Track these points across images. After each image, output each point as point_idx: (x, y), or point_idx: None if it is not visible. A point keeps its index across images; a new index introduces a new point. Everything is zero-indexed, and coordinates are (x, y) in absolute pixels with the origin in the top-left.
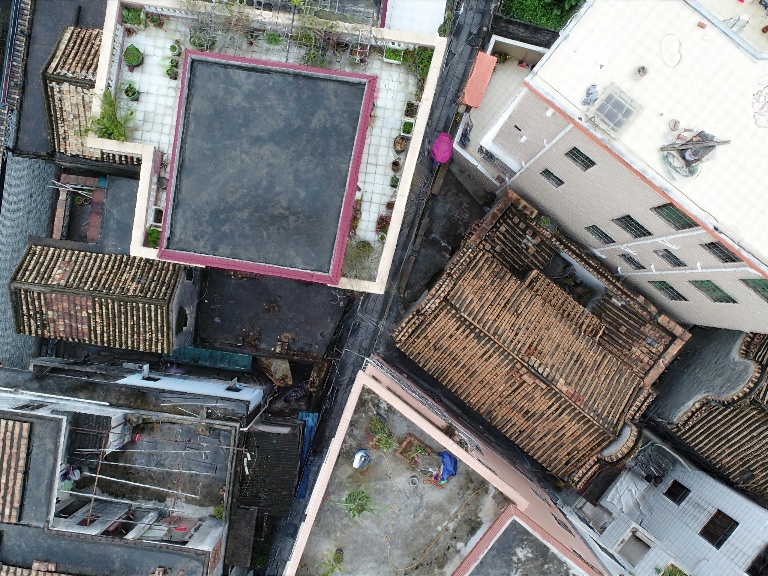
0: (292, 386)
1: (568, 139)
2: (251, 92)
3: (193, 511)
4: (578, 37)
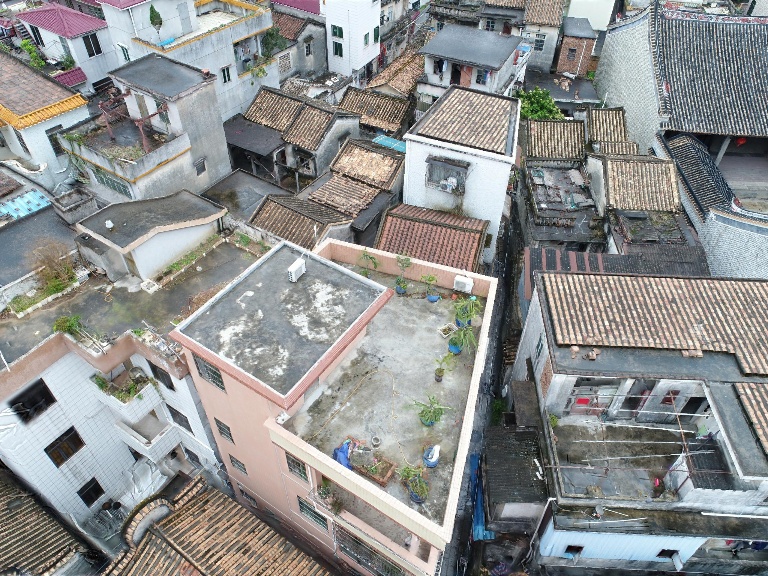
0: (508, 575)
1: None
2: None
3: (577, 421)
4: None
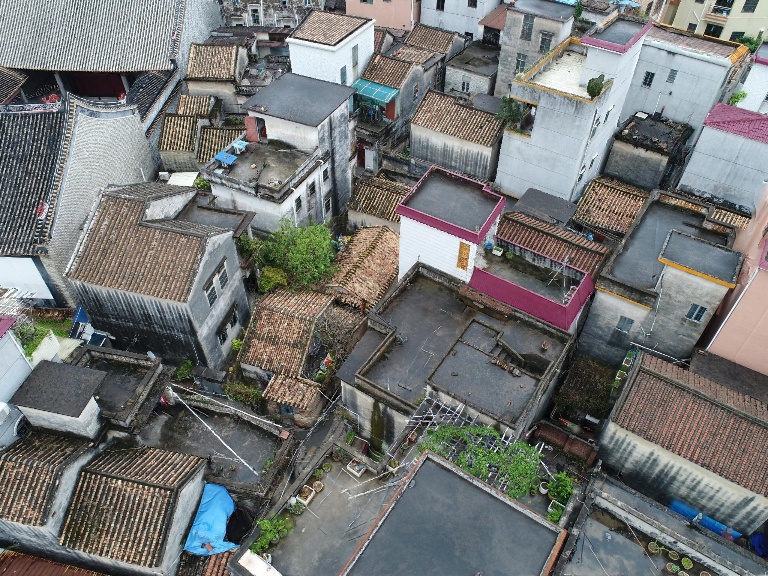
0: None
1: None
2: None
3: None
4: None
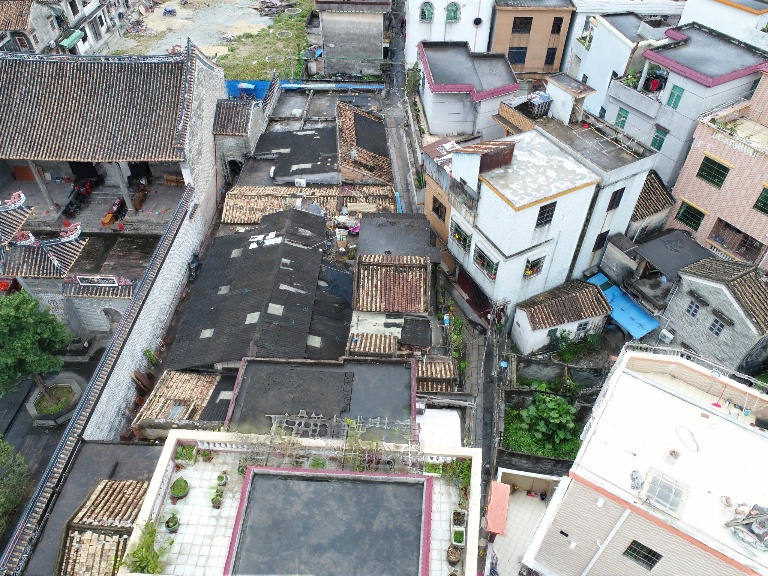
0: None
1: (624, 532)
2: (311, 500)
3: None
4: (604, 432)
